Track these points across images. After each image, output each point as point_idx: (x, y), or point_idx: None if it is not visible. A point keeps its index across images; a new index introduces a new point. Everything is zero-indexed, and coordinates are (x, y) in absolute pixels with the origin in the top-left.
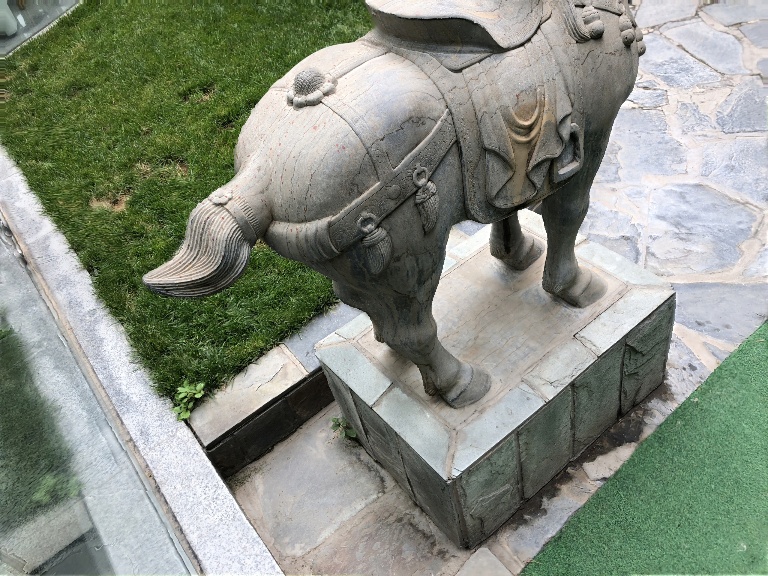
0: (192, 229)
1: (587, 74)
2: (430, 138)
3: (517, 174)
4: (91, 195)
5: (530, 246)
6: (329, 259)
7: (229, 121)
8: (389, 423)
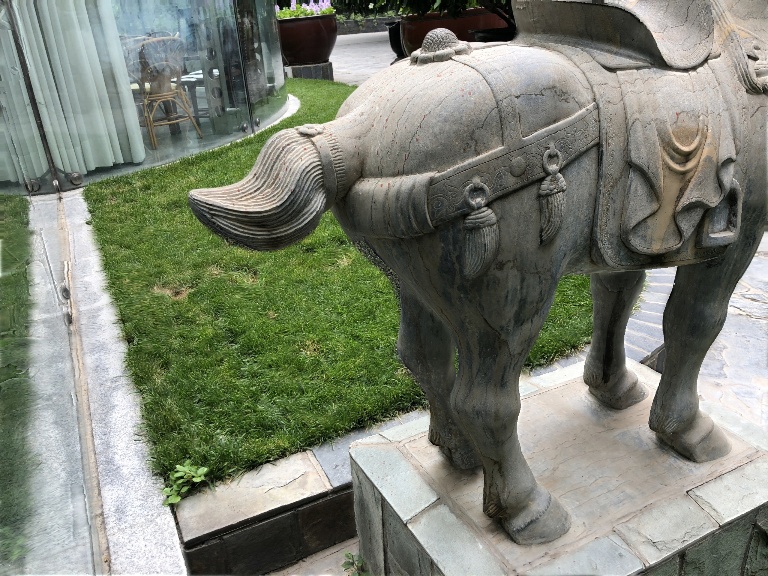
0: (265, 155)
1: (754, 130)
2: (571, 121)
3: (662, 211)
4: (159, 281)
5: (633, 382)
6: (417, 236)
7: (314, 248)
8: (426, 546)
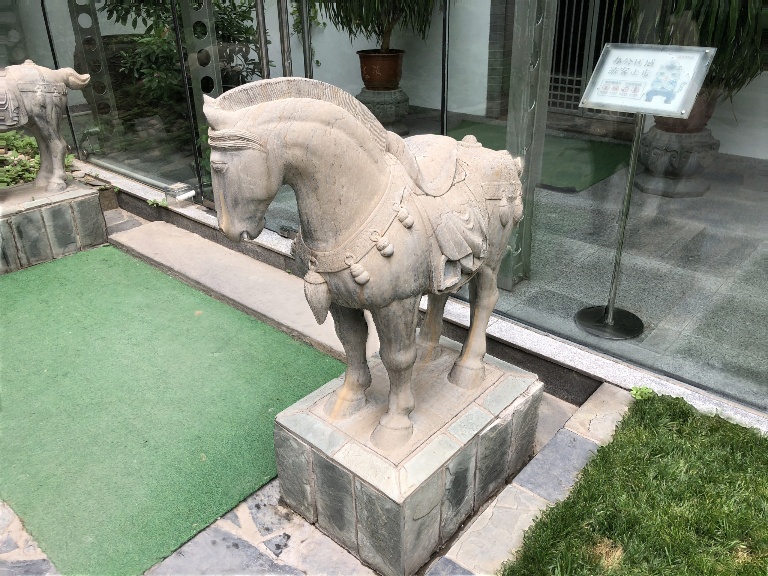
0: None
1: None
2: None
3: None
4: None
5: None
6: None
7: None
8: None
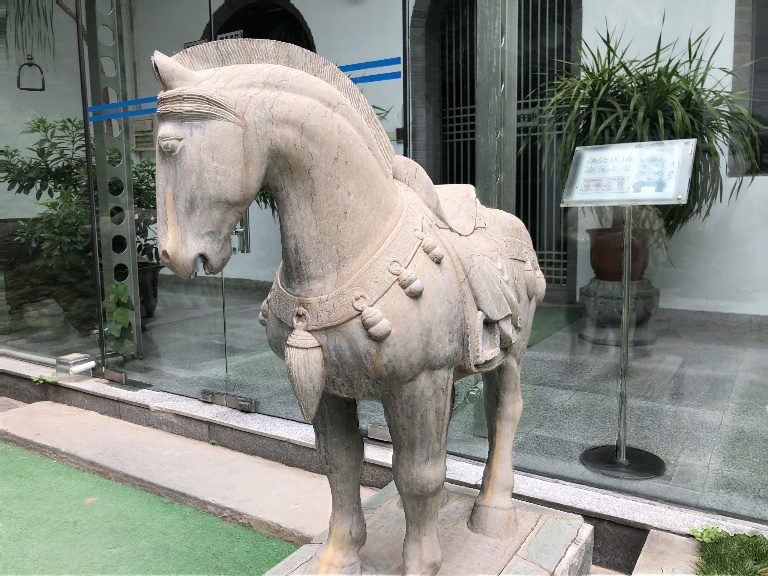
0: None
1: None
2: None
3: None
4: None
5: None
6: None
7: None
8: None
